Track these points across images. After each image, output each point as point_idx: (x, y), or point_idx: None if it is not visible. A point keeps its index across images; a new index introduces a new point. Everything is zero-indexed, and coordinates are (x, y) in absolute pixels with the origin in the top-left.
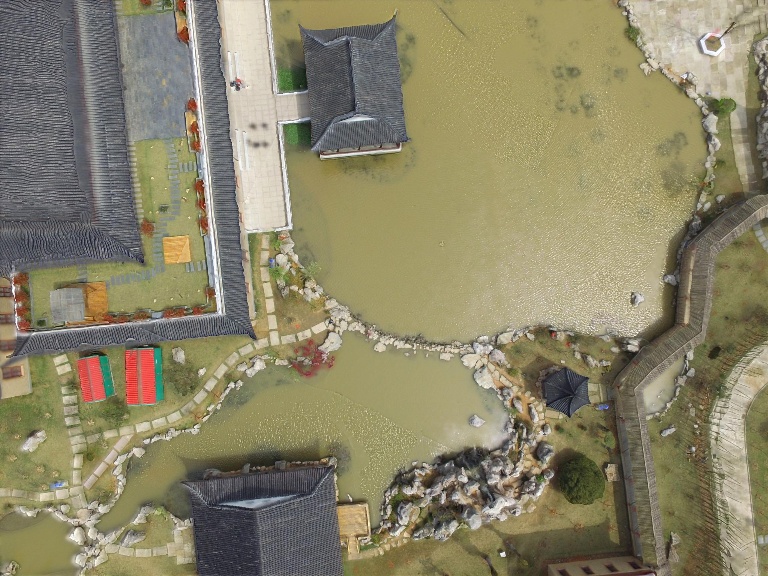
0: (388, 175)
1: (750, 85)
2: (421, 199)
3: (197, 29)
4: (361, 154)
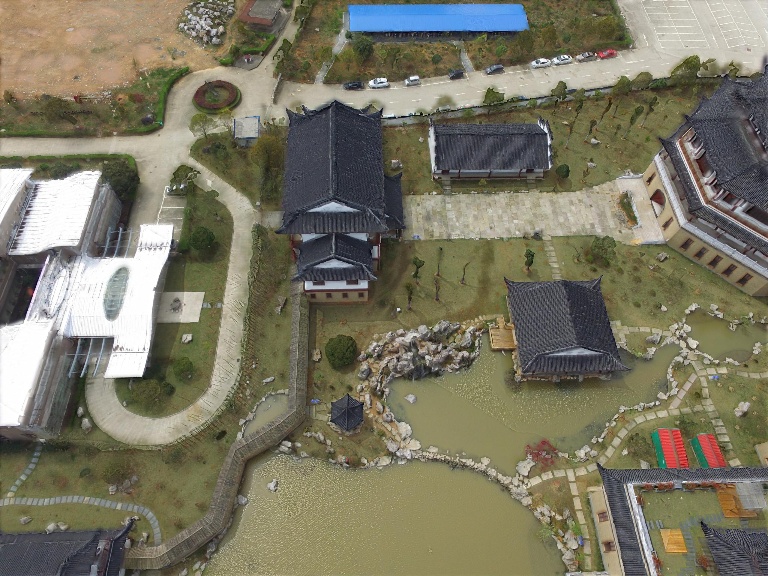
0: None
1: None
2: None
3: None
4: None
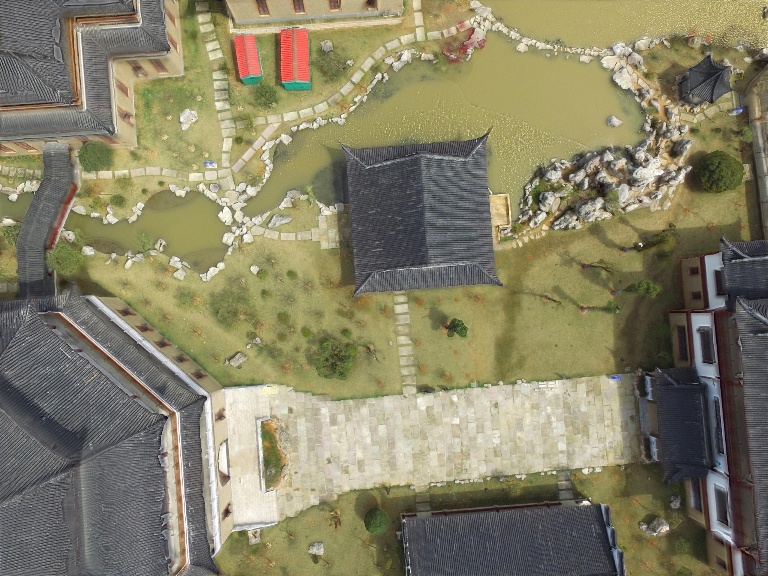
0: None
1: None
2: None
3: None
4: None
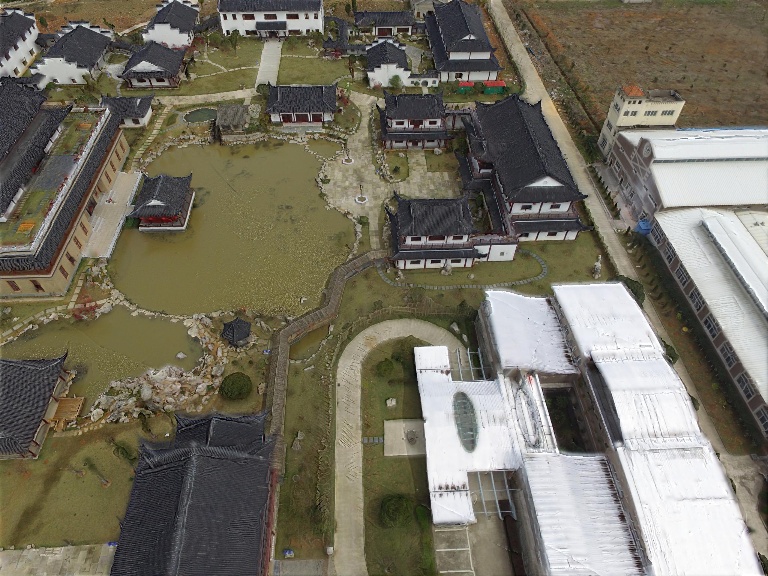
0: (175, 240)
1: (381, 215)
2: (192, 254)
3: (87, 163)
4: (162, 228)
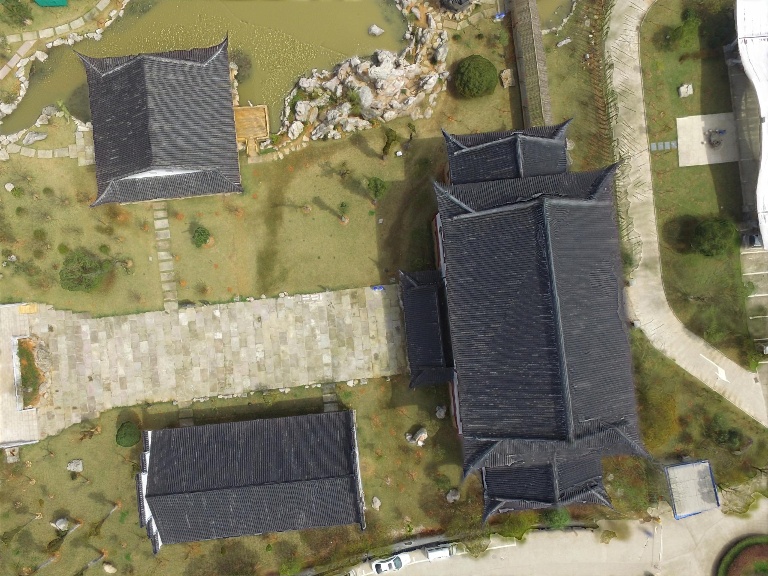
0: None
1: None
2: None
3: None
4: None
